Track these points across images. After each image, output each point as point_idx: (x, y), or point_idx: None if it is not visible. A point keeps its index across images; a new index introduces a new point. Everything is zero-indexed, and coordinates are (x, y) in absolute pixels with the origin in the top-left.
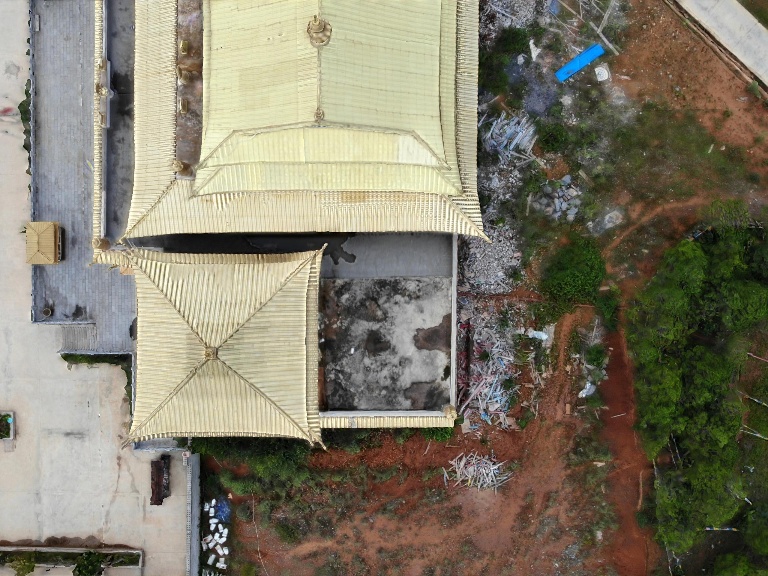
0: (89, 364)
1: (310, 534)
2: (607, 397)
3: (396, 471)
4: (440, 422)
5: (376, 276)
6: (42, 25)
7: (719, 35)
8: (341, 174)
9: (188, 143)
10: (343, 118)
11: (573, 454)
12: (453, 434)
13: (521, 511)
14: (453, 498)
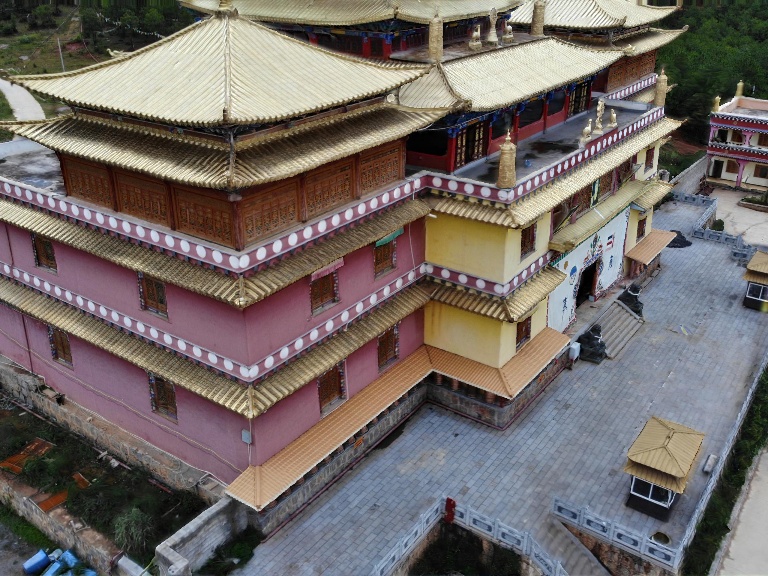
0: None
1: None
2: None
3: None
4: None
5: None
6: None
7: None
8: None
9: None
10: None
11: None
12: None
13: None
14: None
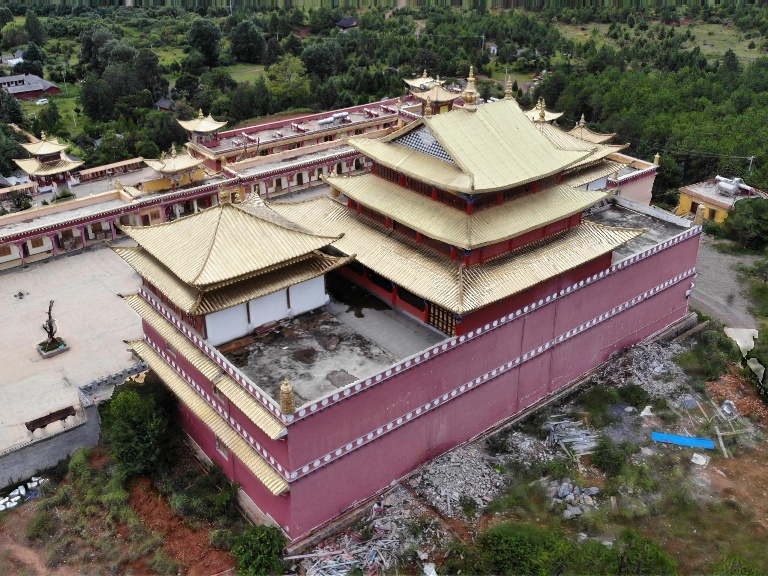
0: None
1: (47, 547)
2: None
3: (172, 571)
4: (270, 426)
5: (361, 332)
6: None
7: None
8: (410, 210)
9: None
10: (439, 131)
11: None
12: None
13: None
14: None
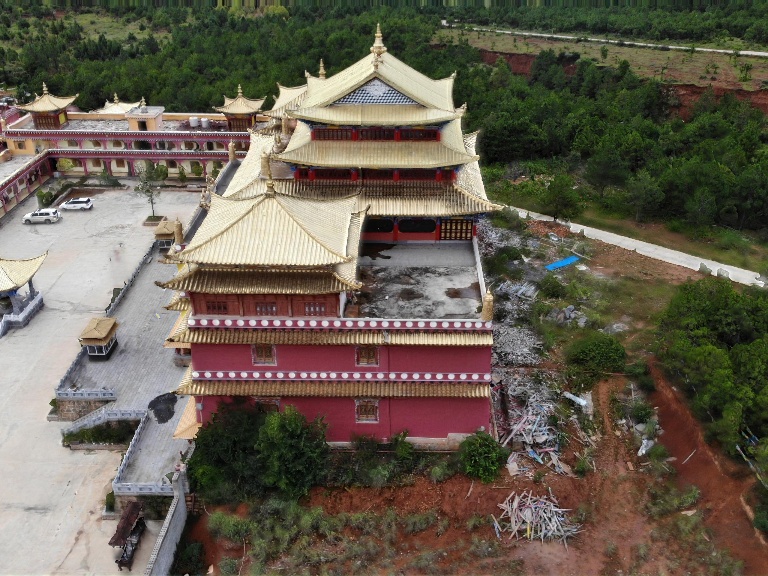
0: (91, 438)
1: None
2: (670, 449)
3: (433, 520)
4: (478, 339)
5: (409, 265)
6: (153, 262)
7: (665, 260)
8: (385, 155)
9: (272, 168)
10: None
11: (653, 506)
12: (500, 475)
13: (606, 567)
14: (511, 552)
